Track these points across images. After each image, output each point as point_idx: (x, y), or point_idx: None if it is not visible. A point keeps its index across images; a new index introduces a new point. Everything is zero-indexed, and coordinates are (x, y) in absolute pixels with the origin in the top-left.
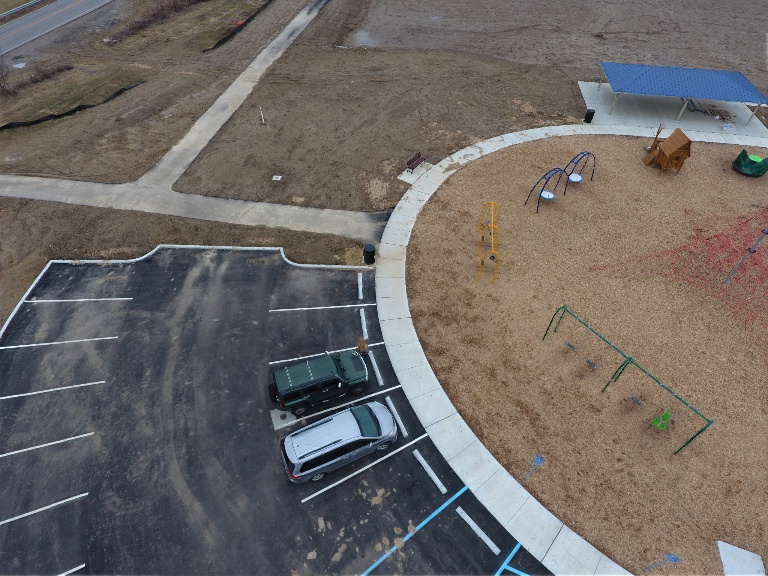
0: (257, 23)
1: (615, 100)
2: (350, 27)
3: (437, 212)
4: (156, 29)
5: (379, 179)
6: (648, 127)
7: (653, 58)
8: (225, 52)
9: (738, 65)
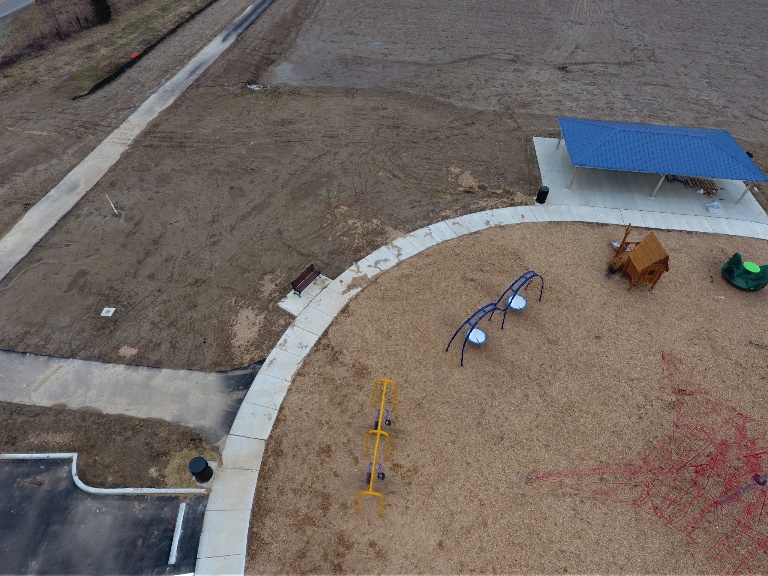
0: (155, 55)
1: (575, 173)
2: (271, 58)
3: (322, 369)
4: (25, 65)
5: (252, 309)
6: (616, 208)
7: (624, 99)
8: (101, 99)
9: (722, 108)
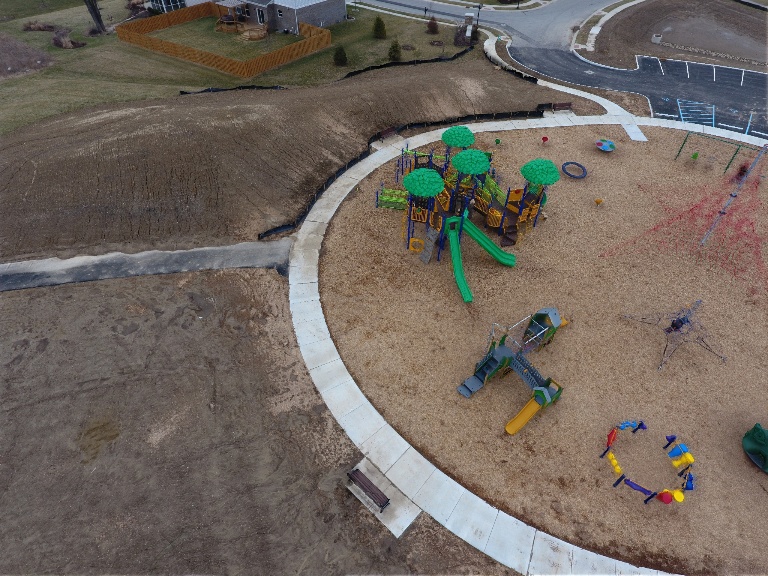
0: None
1: None
2: None
3: None
4: None
5: None
6: None
7: None
8: None
9: None
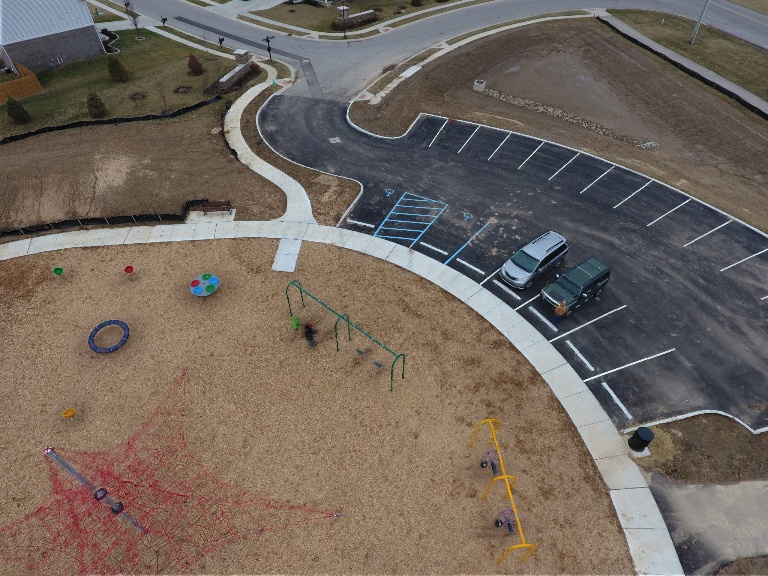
0: None
1: None
2: None
3: None
4: None
5: None
6: None
7: None
8: None
9: None
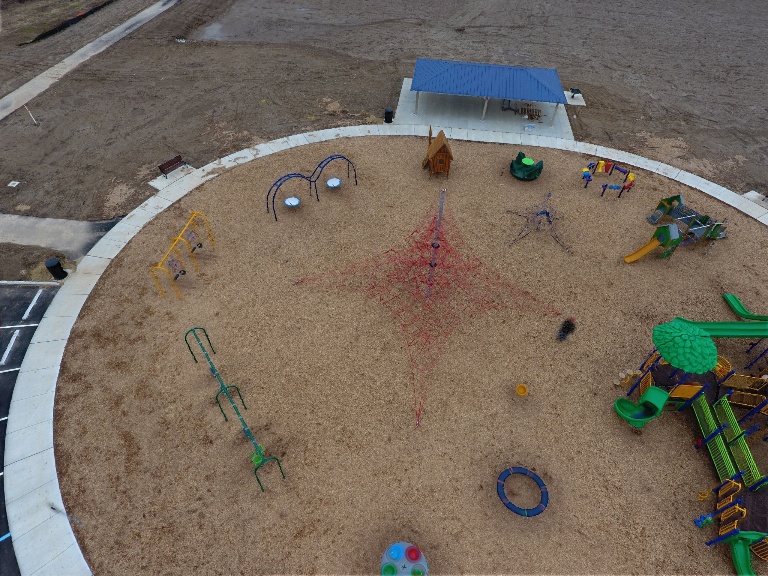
0: (99, 15)
1: (417, 99)
2: (204, 19)
3: (168, 221)
4: None
5: (127, 185)
6: (449, 127)
7: (503, 53)
8: (43, 46)
9: (585, 61)
